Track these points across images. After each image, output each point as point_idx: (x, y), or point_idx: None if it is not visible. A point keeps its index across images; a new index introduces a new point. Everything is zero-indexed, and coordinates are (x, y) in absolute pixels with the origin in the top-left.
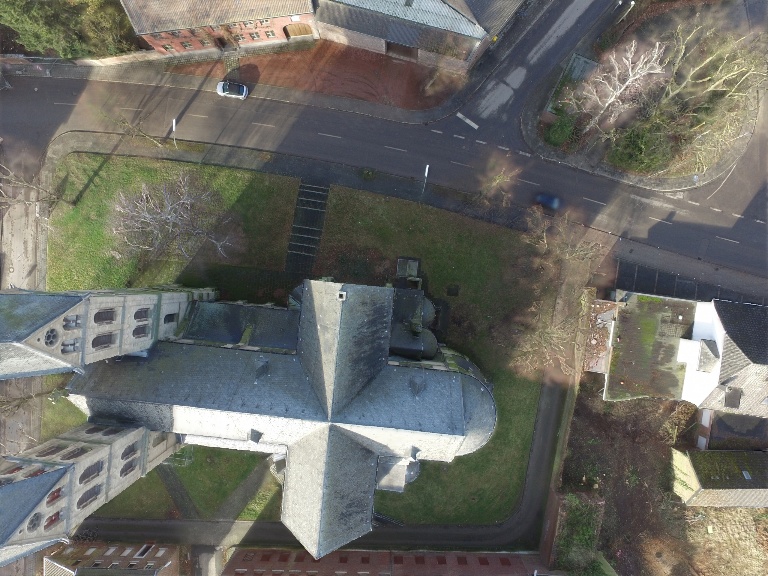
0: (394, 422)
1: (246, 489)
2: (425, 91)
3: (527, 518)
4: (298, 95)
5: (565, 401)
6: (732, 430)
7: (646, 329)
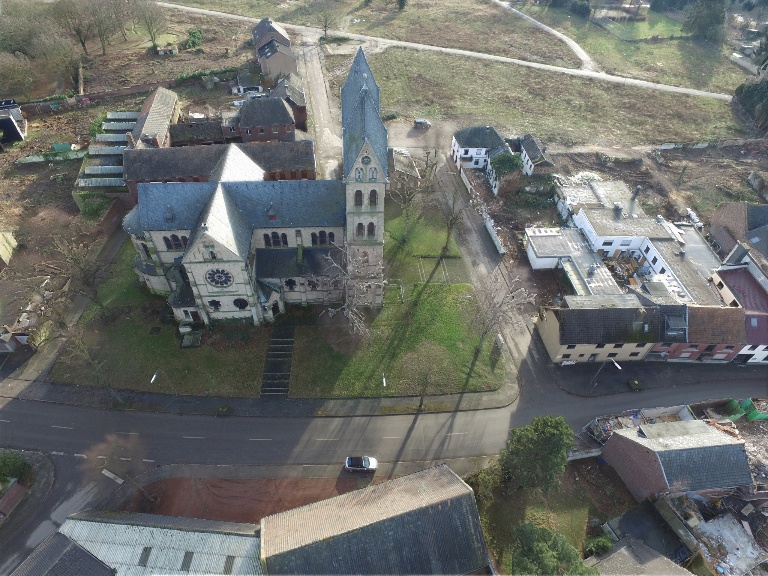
0: (181, 187)
1: None
2: (154, 498)
3: None
4: (294, 473)
5: None
6: None
7: None
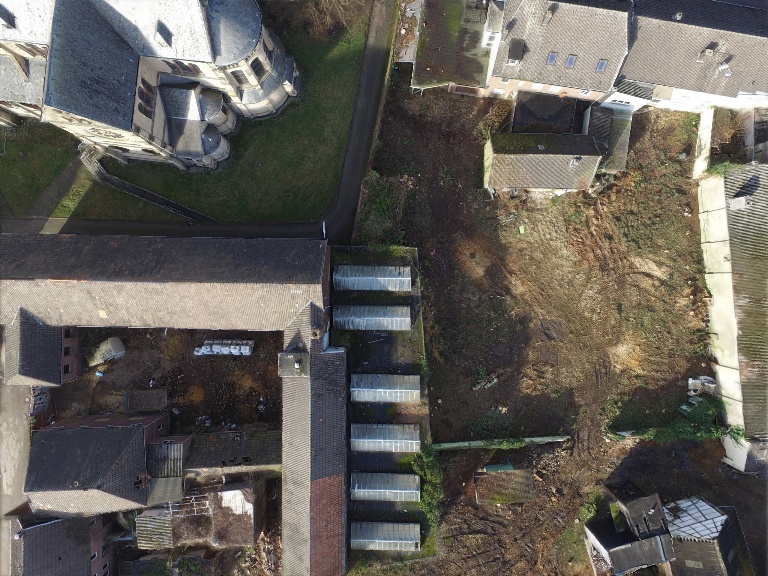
0: None
1: (60, 185)
2: None
3: (342, 217)
4: None
5: (380, 100)
6: (535, 116)
7: (452, 15)
